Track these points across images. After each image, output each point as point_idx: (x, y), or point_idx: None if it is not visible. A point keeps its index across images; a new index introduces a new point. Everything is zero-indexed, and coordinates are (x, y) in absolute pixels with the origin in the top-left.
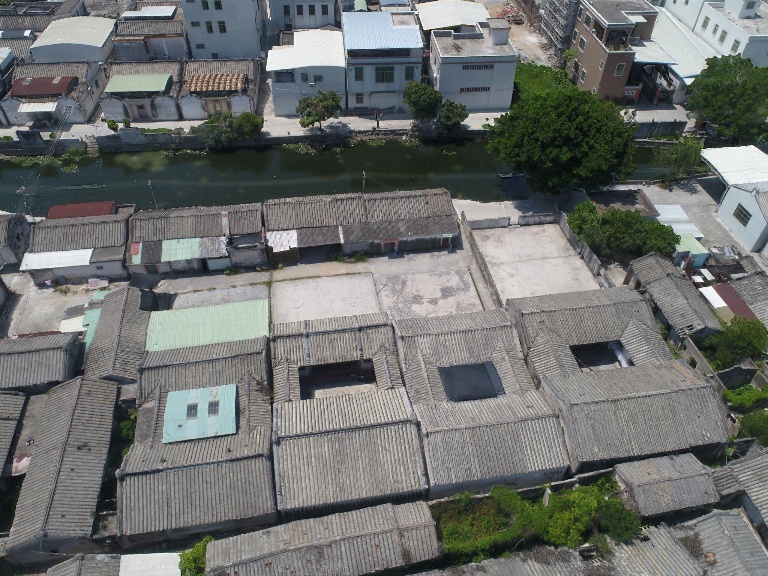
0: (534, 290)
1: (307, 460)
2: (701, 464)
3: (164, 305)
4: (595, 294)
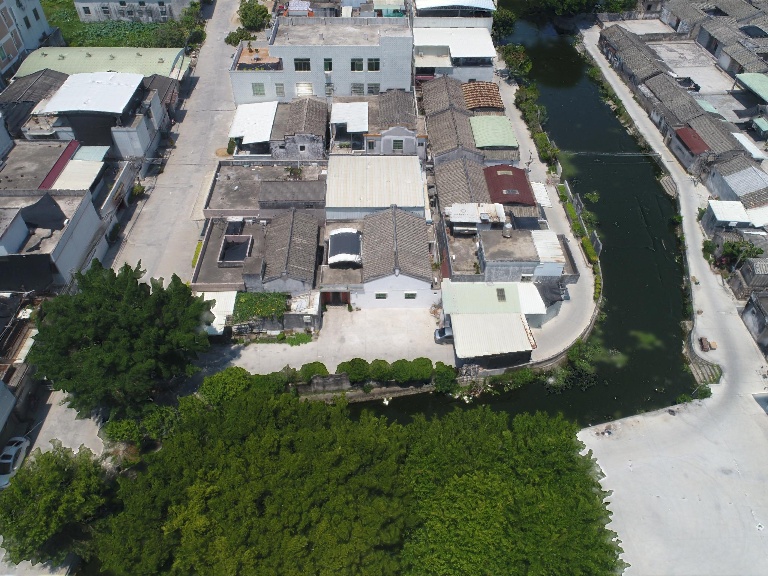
0: (657, 32)
1: None
2: (762, 2)
3: (739, 125)
4: (677, 7)
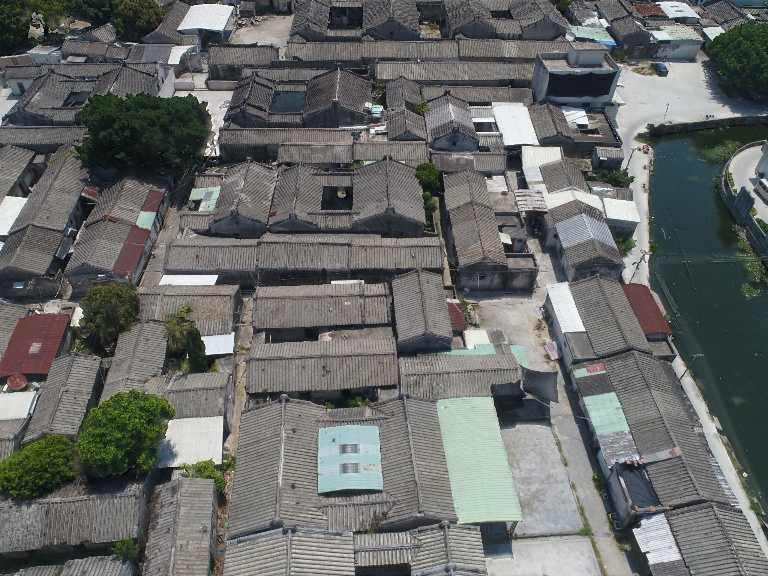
0: None
1: (264, 567)
2: None
3: (531, 415)
4: None
